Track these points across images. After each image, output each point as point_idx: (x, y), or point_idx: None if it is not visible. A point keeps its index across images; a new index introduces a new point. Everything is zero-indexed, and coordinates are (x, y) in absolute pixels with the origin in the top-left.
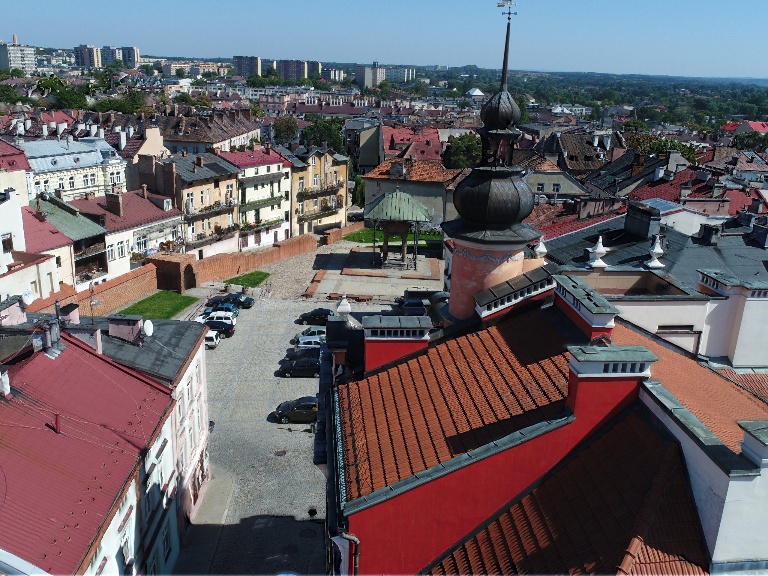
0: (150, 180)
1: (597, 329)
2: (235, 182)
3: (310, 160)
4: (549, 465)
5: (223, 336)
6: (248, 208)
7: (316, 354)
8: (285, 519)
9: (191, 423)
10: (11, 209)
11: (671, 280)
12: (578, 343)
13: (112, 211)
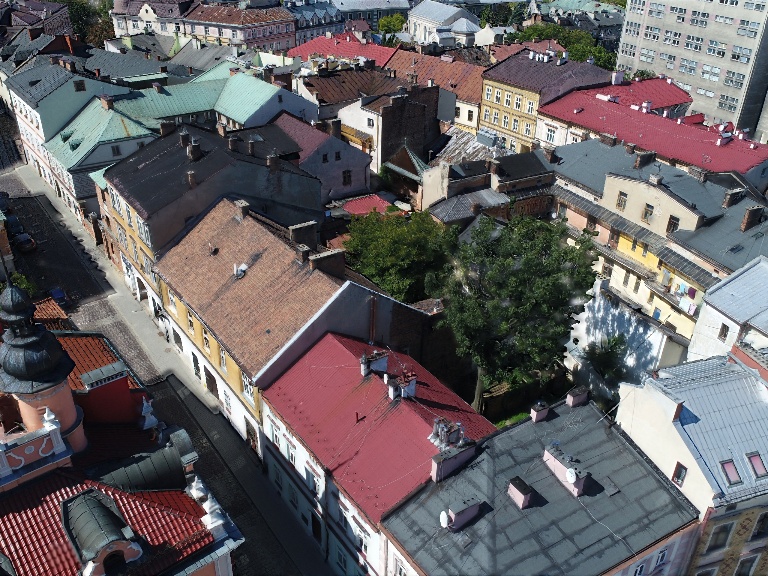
0: None
1: None
2: None
3: None
4: None
5: None
6: None
7: None
8: None
9: None
10: None
11: None
12: None
13: None
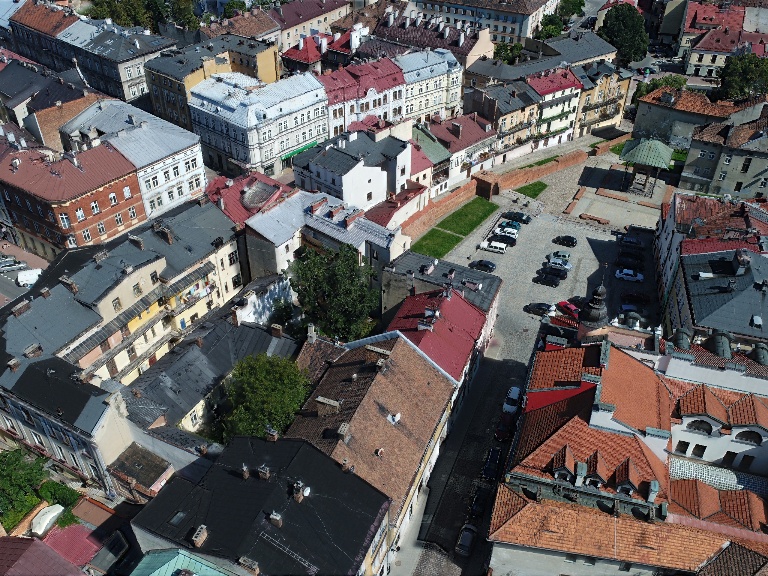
0: (480, 106)
1: (602, 365)
2: (537, 106)
3: (598, 80)
4: (574, 395)
5: (509, 246)
6: (543, 122)
7: (557, 273)
8: (521, 364)
9: (490, 320)
10: (407, 153)
11: (657, 342)
12: (598, 365)
13: (455, 134)
